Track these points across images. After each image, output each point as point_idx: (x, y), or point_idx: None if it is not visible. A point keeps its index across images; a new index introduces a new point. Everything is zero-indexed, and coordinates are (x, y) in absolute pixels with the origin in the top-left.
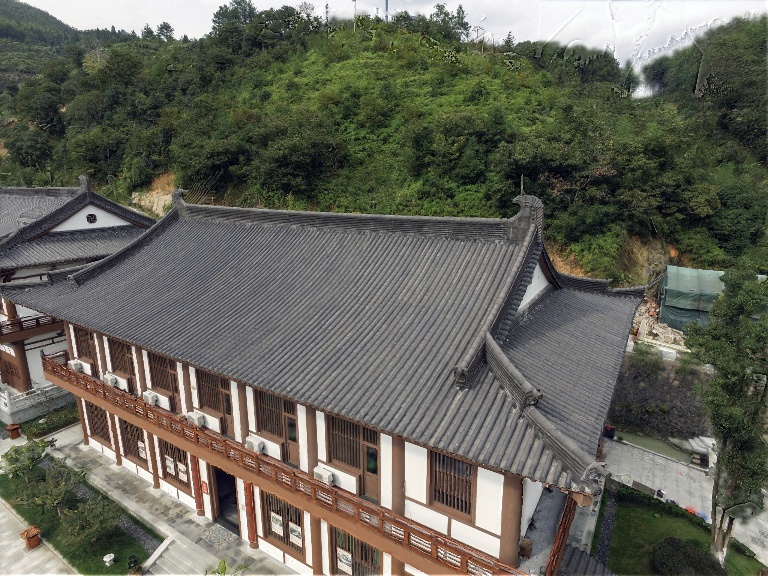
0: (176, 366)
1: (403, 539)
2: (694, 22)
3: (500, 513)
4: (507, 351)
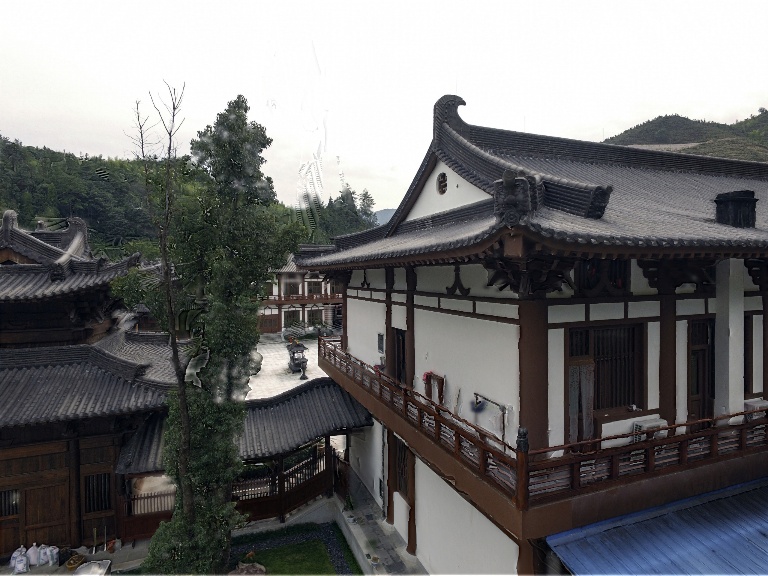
0: None
1: None
2: None
3: None
4: None
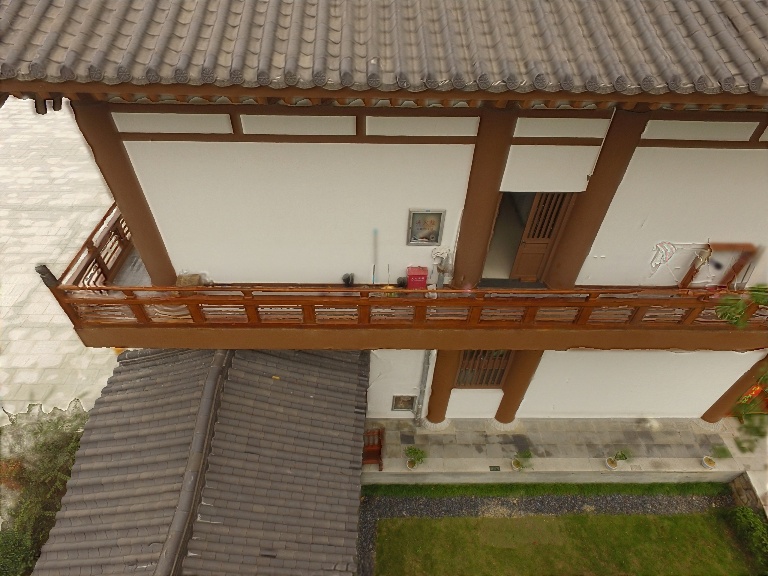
0: None
1: None
2: None
3: None
4: None
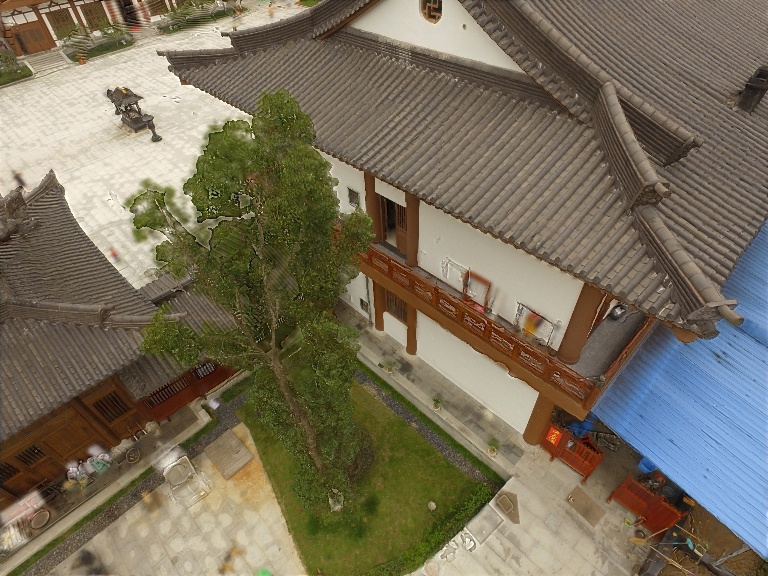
0: None
1: None
2: None
3: None
4: (319, 46)
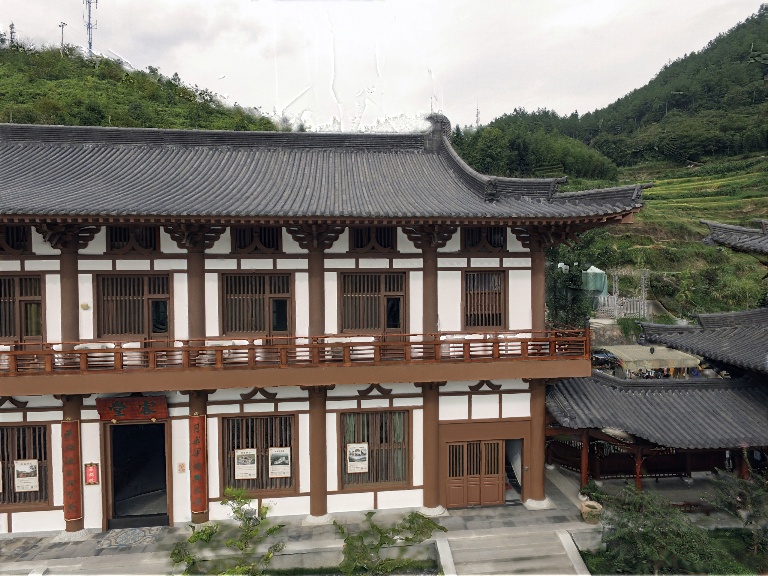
0: (44, 282)
1: (463, 355)
2: (389, 113)
3: (530, 307)
4: None
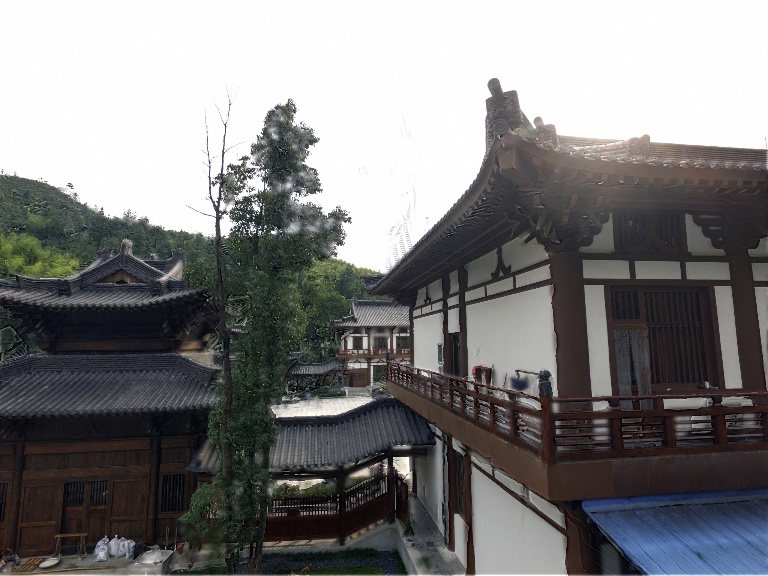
0: None
1: None
2: None
3: None
4: None
